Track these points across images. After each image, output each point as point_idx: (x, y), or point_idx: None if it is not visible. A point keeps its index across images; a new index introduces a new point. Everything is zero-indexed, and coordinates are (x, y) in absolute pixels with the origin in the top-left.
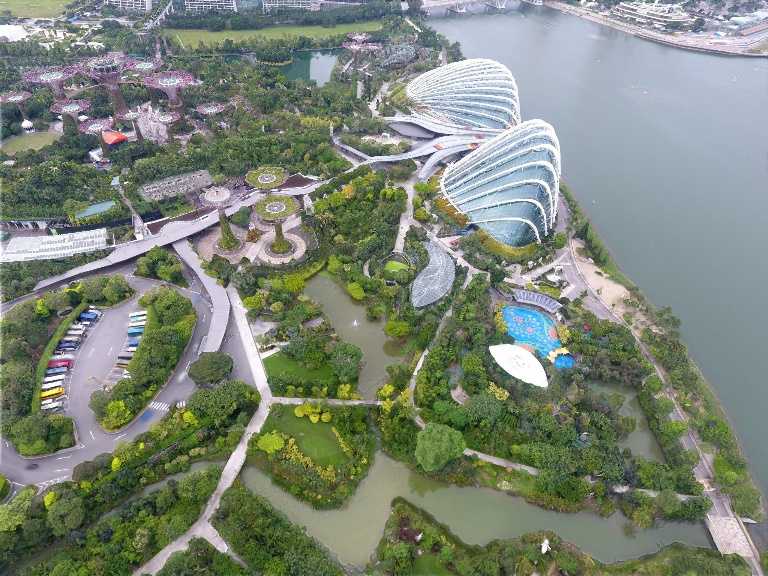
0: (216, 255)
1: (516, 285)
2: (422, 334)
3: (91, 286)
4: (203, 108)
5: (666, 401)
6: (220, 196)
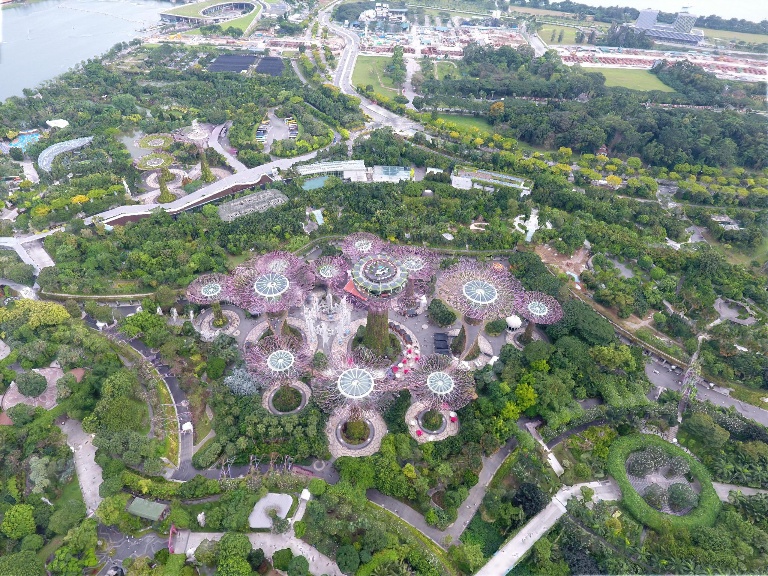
0: (214, 155)
1: (7, 154)
2: (100, 130)
3: (289, 139)
4: (225, 294)
5: (3, 107)
6: (195, 133)
